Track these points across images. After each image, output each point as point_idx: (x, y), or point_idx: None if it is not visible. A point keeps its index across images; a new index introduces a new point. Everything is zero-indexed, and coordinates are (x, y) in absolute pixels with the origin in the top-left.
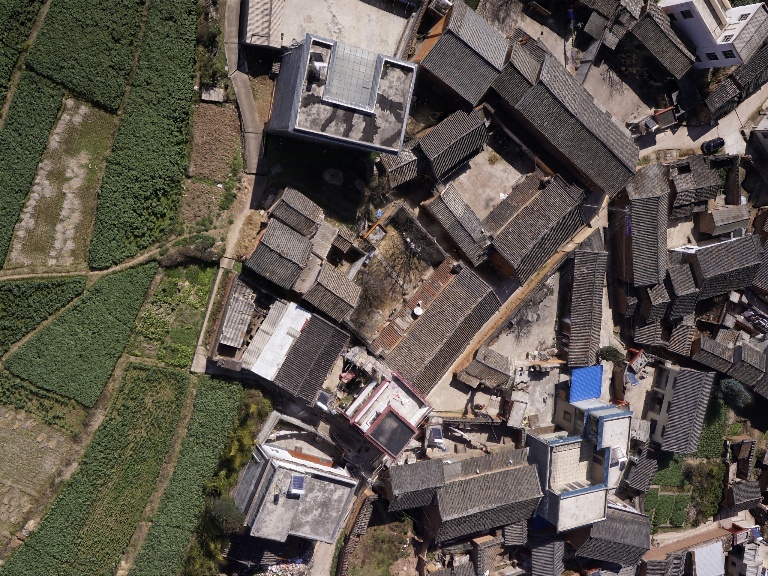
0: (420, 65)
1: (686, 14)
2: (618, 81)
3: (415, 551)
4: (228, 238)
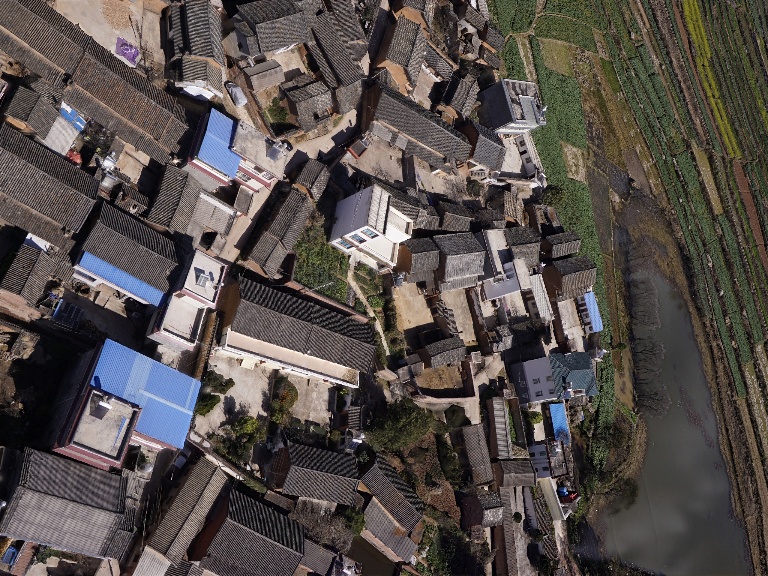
0: None
1: None
2: None
3: None
4: None
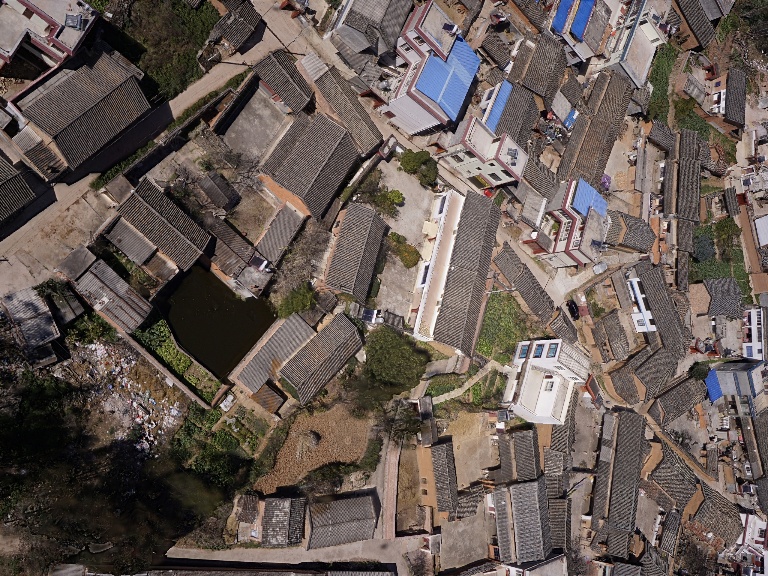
0: None
1: None
2: None
3: None
4: None
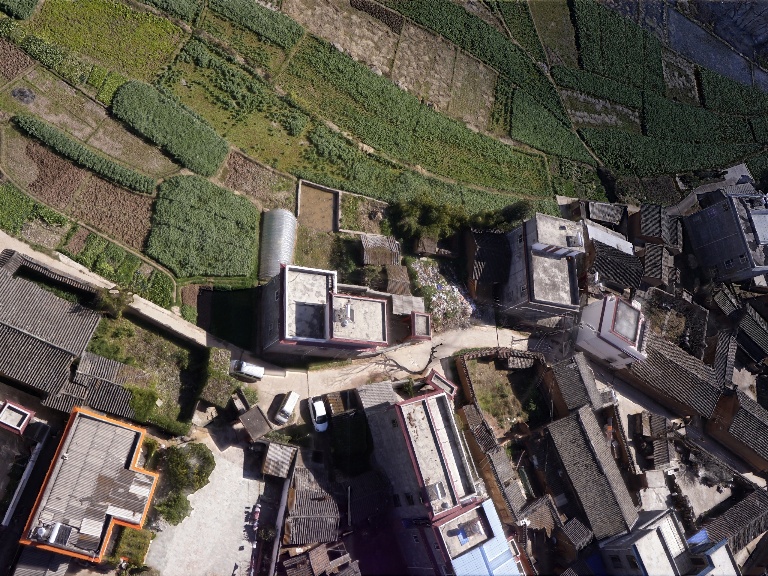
0: (767, 298)
1: None
2: None
3: (508, 433)
4: (629, 205)
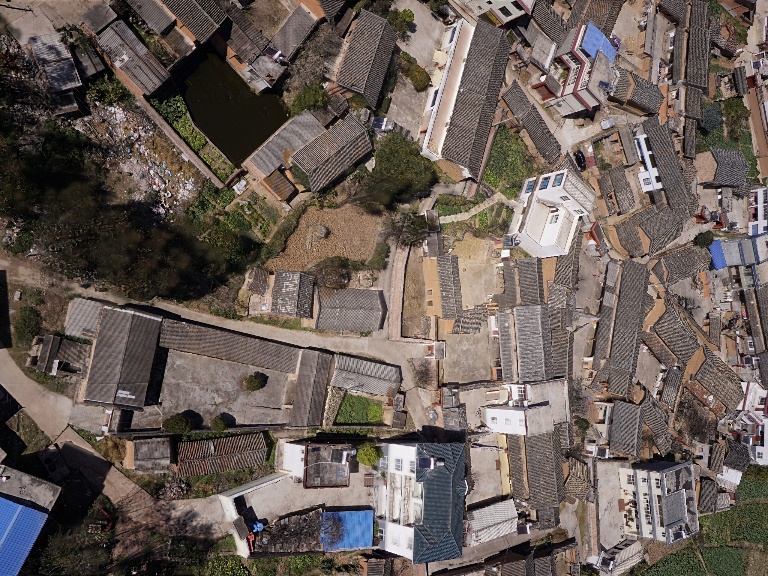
0: None
1: None
2: None
3: None
4: None
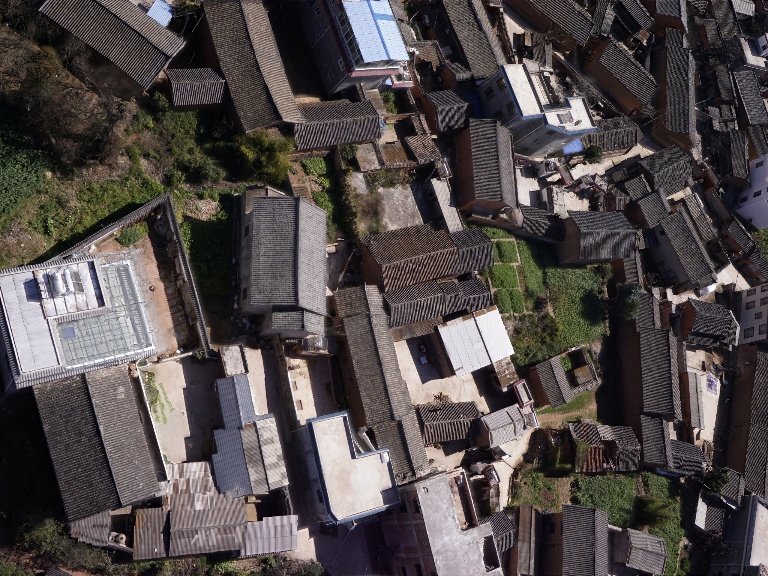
0: None
1: (759, 165)
2: (700, 151)
3: None
4: None
